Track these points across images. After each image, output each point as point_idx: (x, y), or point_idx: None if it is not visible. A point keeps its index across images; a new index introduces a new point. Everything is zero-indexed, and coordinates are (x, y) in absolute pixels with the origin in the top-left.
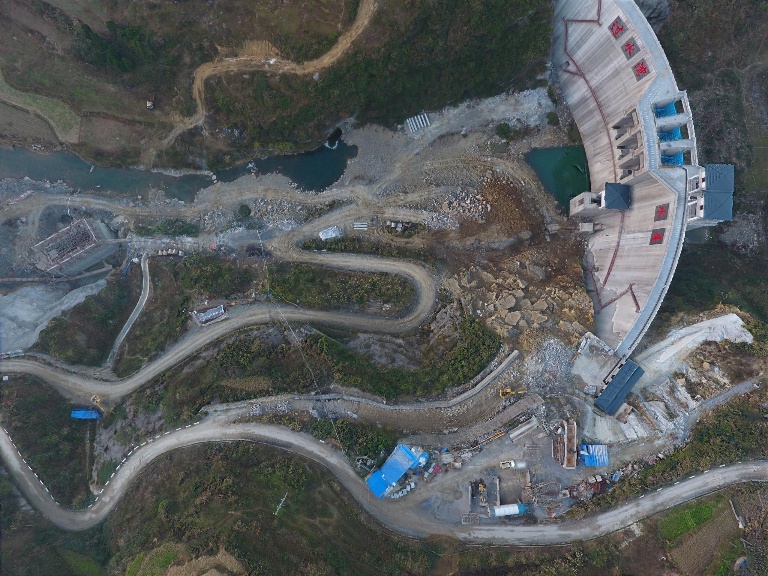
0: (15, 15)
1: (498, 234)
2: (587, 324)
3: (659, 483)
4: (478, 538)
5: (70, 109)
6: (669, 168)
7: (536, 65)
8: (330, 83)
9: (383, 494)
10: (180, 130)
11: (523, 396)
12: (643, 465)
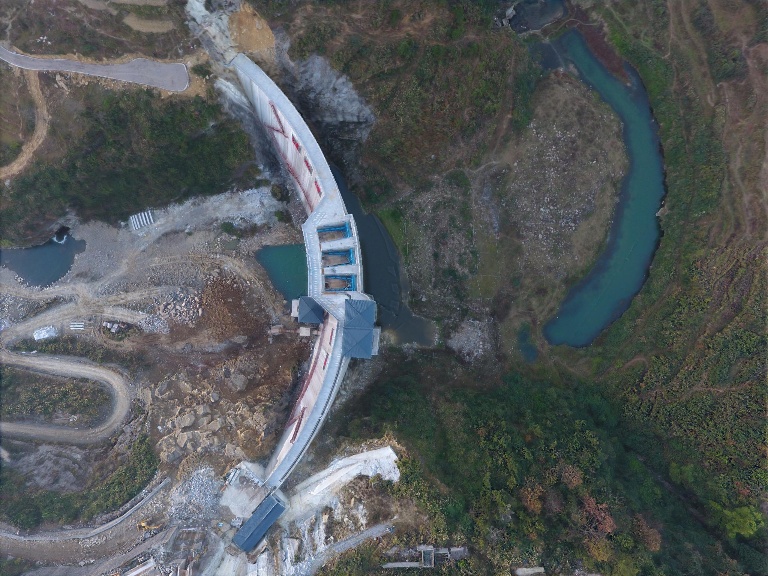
0: None
1: (209, 339)
2: (255, 448)
3: None
4: None
5: None
6: (332, 294)
7: (249, 168)
8: (23, 189)
9: None
10: None
11: (165, 528)
12: None
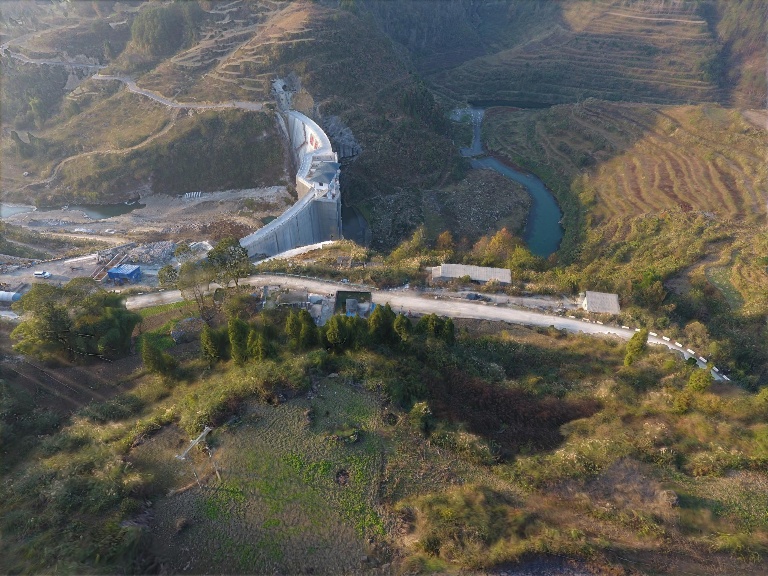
0: None
1: (207, 238)
2: None
3: (165, 287)
4: None
5: None
6: None
7: (277, 170)
8: (133, 157)
9: None
10: (33, 184)
11: None
12: None
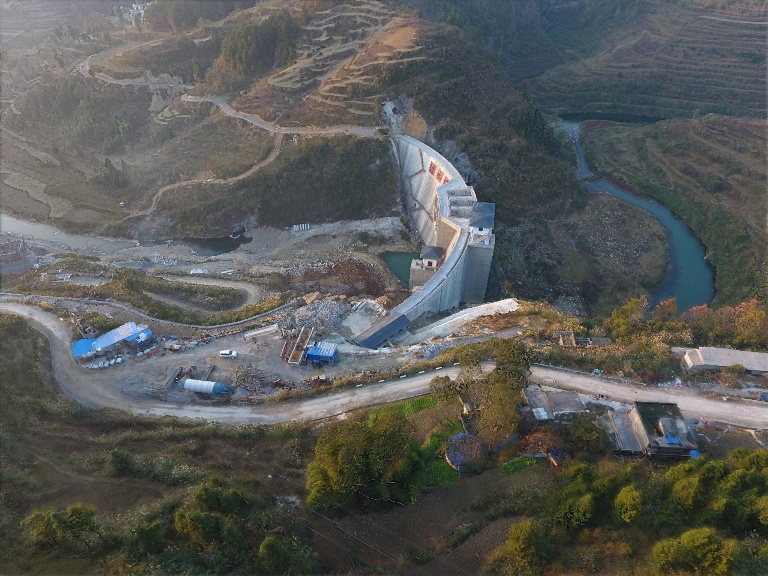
0: (76, 166)
1: (336, 281)
2: None
3: (383, 376)
4: (155, 415)
5: (70, 204)
6: (457, 218)
7: (389, 200)
8: (239, 188)
9: (81, 355)
10: (132, 216)
11: None
12: (378, 373)
